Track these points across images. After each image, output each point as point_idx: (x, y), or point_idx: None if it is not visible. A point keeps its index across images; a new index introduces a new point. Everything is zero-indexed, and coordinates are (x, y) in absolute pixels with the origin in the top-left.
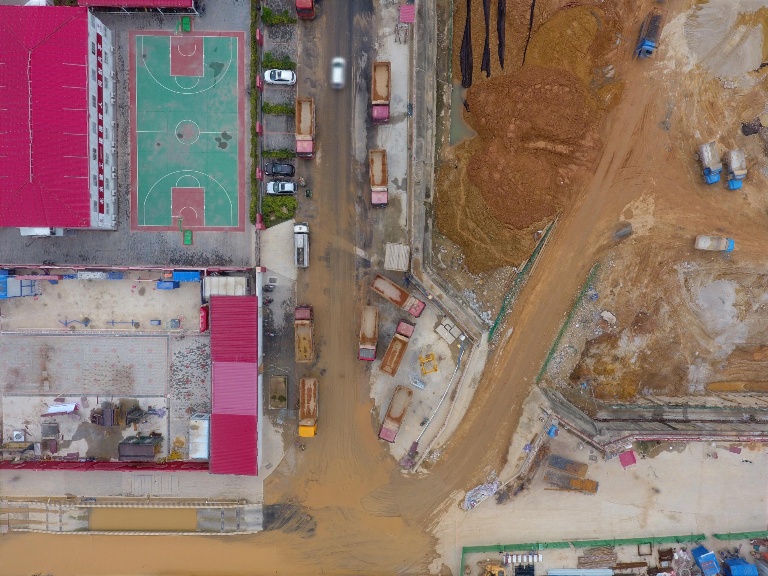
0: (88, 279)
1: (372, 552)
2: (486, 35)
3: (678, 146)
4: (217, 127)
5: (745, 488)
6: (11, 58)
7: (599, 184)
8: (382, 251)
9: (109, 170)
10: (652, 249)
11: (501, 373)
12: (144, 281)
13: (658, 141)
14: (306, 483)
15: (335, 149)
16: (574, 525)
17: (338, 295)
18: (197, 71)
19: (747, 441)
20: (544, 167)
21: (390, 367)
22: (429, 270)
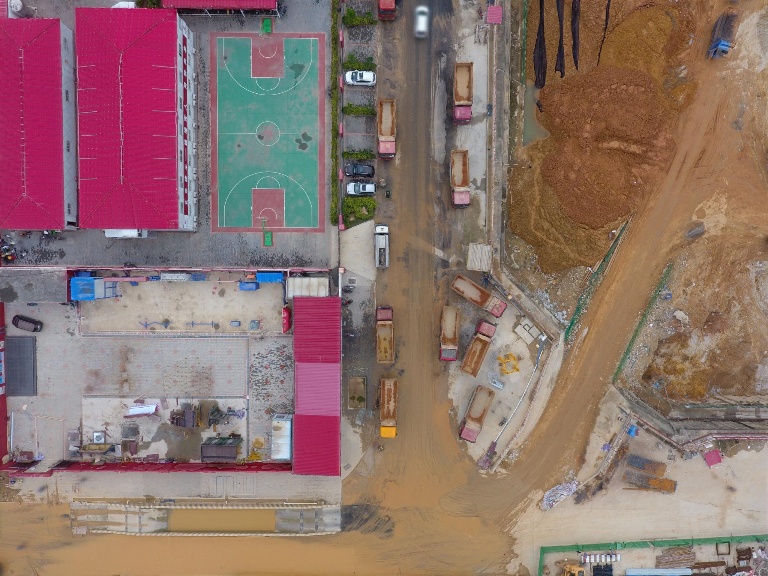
0: None
1: (450, 552)
2: (560, 35)
3: (750, 145)
4: (297, 128)
5: None
6: (101, 60)
7: (672, 184)
8: (461, 251)
9: (191, 172)
10: (724, 248)
11: (577, 373)
12: (224, 282)
13: (730, 141)
14: (384, 483)
15: (414, 150)
16: (652, 525)
17: (417, 295)
18: (278, 73)
19: None
20: (619, 167)
21: (470, 367)
22: (505, 270)
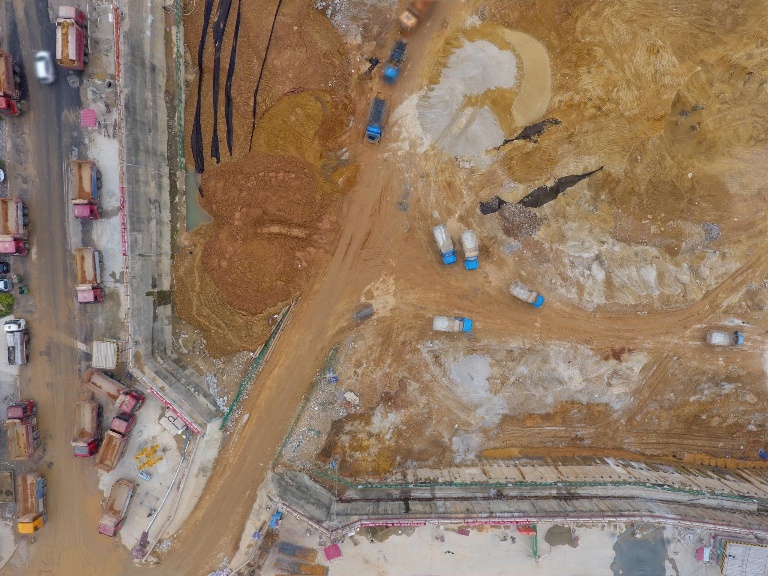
0: None
1: None
2: (214, 121)
3: (417, 226)
4: None
5: (475, 569)
6: None
7: (338, 266)
8: None
9: None
10: (394, 329)
11: (236, 459)
12: None
13: (396, 222)
14: (40, 574)
15: (50, 244)
16: None
17: (61, 389)
18: None
19: None
20: (276, 253)
21: (111, 461)
22: (160, 359)
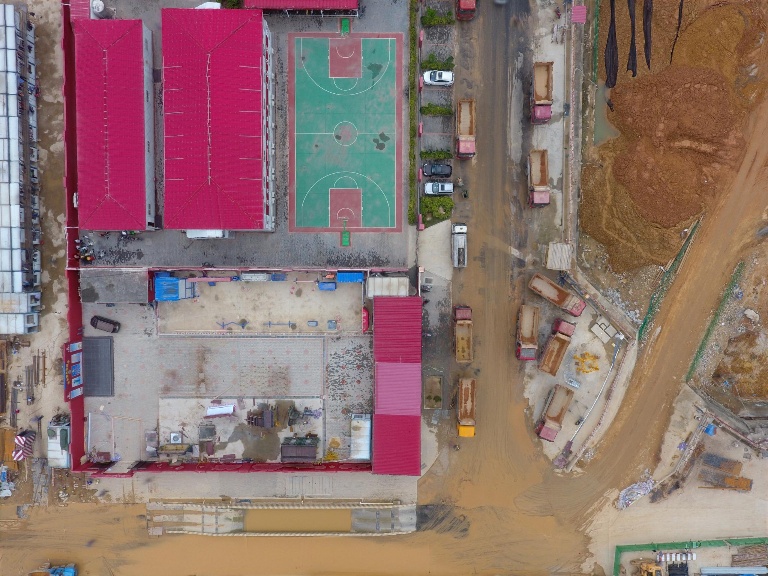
0: (247, 281)
1: (525, 552)
2: (632, 35)
3: None
4: (375, 128)
5: None
6: (188, 61)
7: (742, 182)
8: (537, 251)
9: (270, 172)
10: None
11: (650, 372)
12: (301, 282)
13: None
14: (459, 483)
15: (491, 149)
16: (728, 523)
17: (493, 295)
18: (355, 73)
19: None
20: (691, 166)
21: (548, 366)
22: (579, 269)
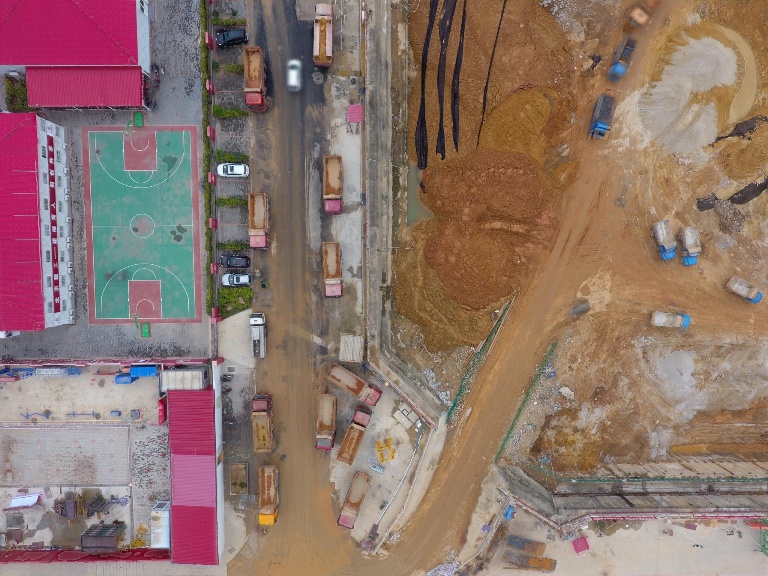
0: None
1: None
2: (440, 118)
3: (634, 222)
4: (172, 220)
5: (701, 563)
6: None
7: (556, 262)
8: (339, 338)
9: (65, 266)
10: (609, 325)
11: (460, 453)
12: (103, 373)
13: (614, 218)
14: (269, 566)
15: (290, 239)
16: None
17: (296, 382)
18: (150, 165)
19: (702, 518)
20: (500, 248)
21: (348, 454)
22: (387, 353)
